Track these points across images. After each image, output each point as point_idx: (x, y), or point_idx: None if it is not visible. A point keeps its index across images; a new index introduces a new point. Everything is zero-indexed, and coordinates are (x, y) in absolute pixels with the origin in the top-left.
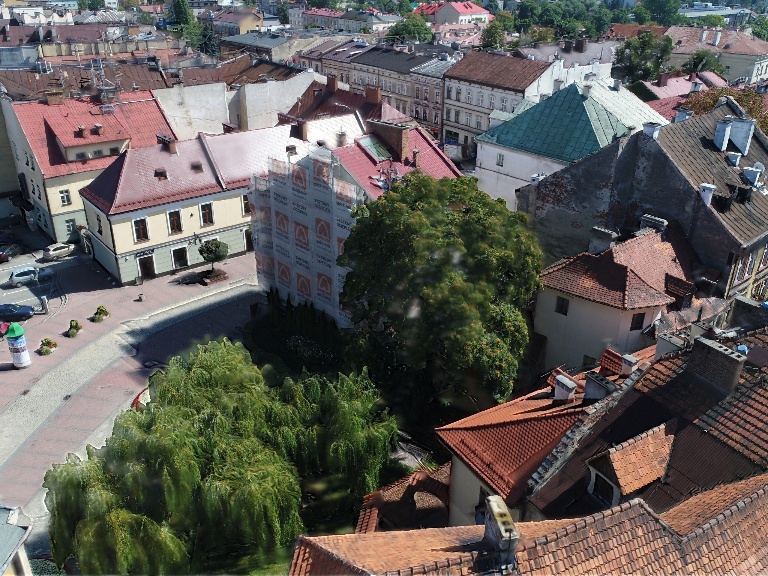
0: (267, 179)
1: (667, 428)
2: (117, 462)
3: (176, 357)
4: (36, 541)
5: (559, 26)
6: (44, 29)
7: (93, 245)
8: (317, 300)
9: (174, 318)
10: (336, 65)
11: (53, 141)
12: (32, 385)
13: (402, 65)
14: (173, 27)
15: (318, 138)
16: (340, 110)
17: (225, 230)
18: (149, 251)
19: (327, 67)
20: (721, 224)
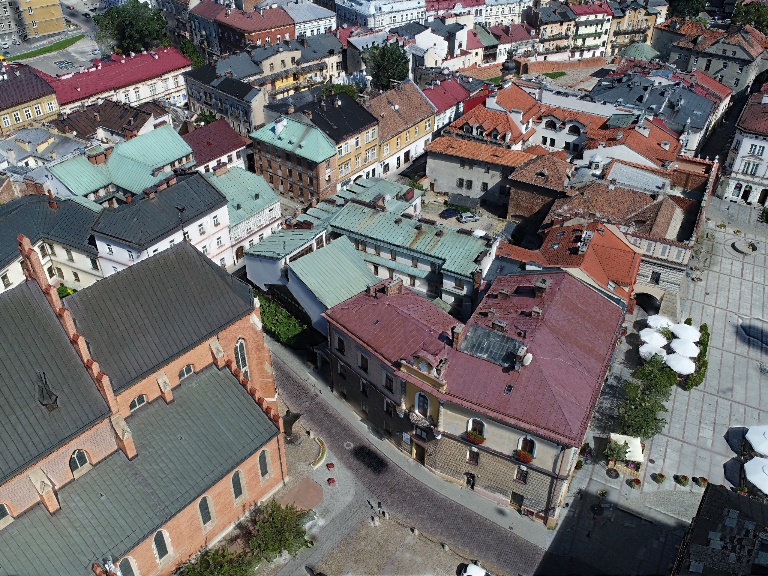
0: None
1: None
2: None
3: None
4: None
5: None
6: None
7: None
8: None
9: None
10: None
11: None
12: None
13: None
14: None
15: None
16: None
17: None
18: None
19: None
20: None
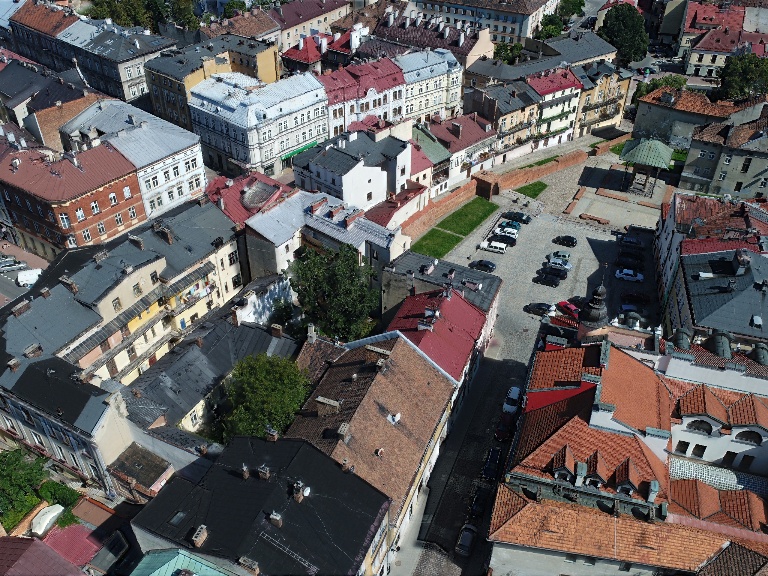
0: None
1: (734, 103)
2: None
3: None
4: (628, 107)
5: None
6: None
7: (686, 60)
8: None
9: (692, 87)
10: None
11: (695, 19)
12: None
13: None
14: None
15: None
16: None
17: None
18: (700, 66)
19: None
20: None
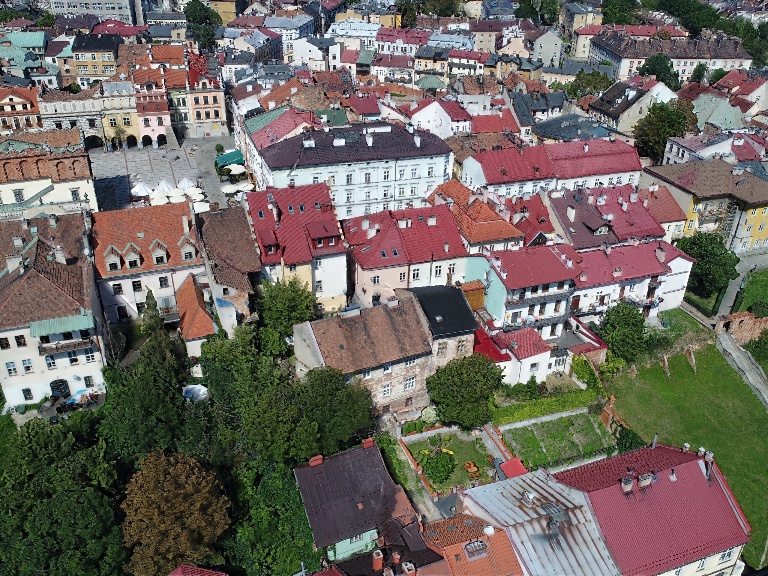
0: None
1: None
2: None
3: None
4: None
5: None
6: None
7: None
8: None
9: None
10: None
11: None
12: None
13: None
14: None
15: None
16: None
17: None
18: None
19: None
20: None
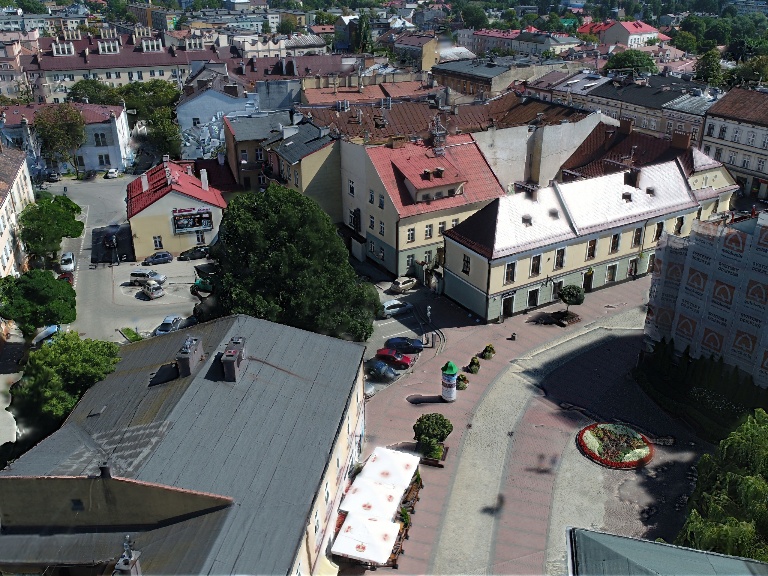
0: (686, 238)
1: None
2: (757, 524)
3: (766, 426)
4: None
5: (748, 48)
6: (285, 60)
7: (445, 282)
8: (729, 355)
9: (557, 359)
10: None
11: (401, 183)
12: (471, 419)
13: (649, 100)
14: (379, 54)
15: (647, 185)
16: (639, 153)
17: (570, 273)
18: (512, 292)
19: None
20: None
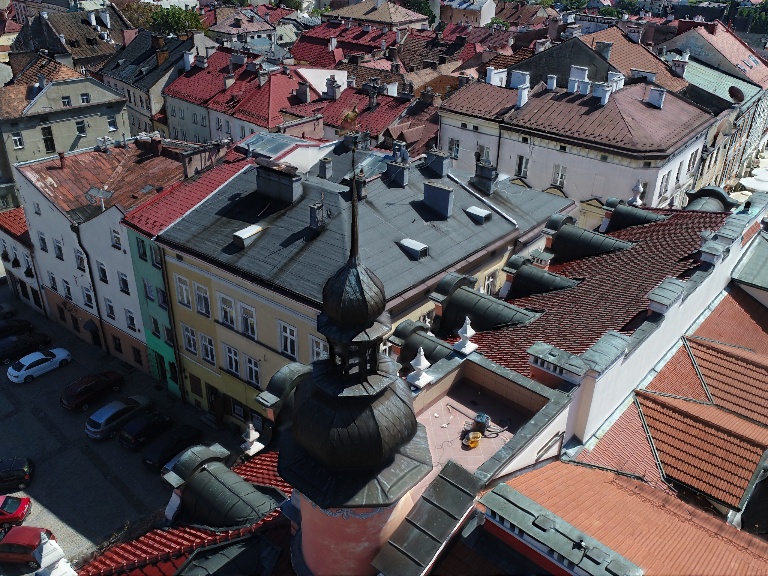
0: None
1: None
2: None
3: None
4: None
5: None
6: None
7: None
8: None
9: None
10: (34, 5)
11: None
12: None
13: None
14: None
15: None
16: None
17: None
18: None
19: (29, 7)
20: (67, 50)
